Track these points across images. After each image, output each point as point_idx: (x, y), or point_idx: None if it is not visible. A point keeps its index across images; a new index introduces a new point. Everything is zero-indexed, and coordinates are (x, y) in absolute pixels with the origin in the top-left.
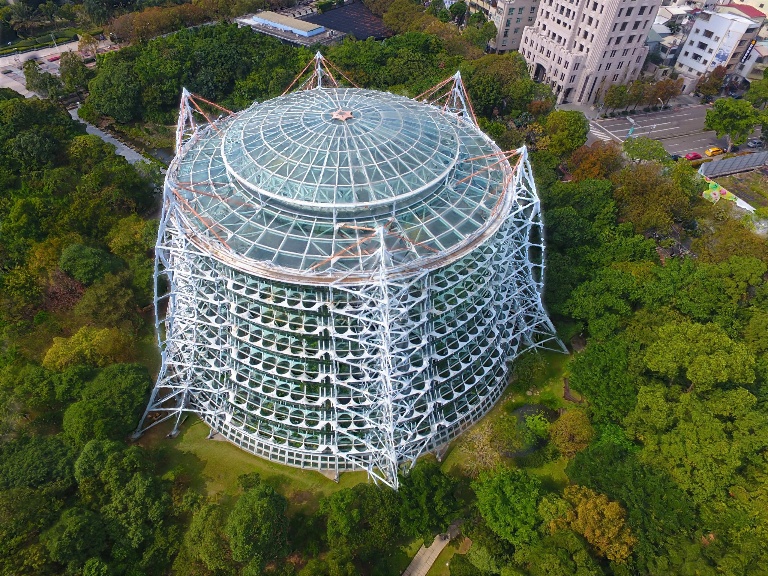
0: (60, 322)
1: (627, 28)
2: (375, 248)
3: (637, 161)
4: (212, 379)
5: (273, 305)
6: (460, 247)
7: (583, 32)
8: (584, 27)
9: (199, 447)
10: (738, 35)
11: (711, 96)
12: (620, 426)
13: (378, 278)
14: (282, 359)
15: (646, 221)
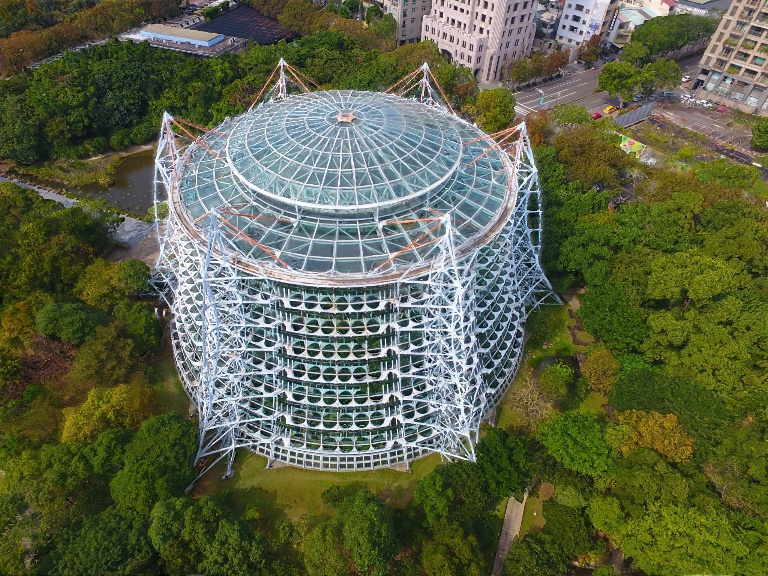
0: (61, 391)
1: (518, 8)
2: (423, 238)
3: (569, 126)
4: (261, 407)
5: (334, 314)
6: (494, 223)
7: (481, 16)
8: (481, 11)
9: (261, 479)
10: (604, 6)
11: (591, 62)
12: (635, 354)
13: (437, 265)
14: (340, 367)
15: (594, 176)
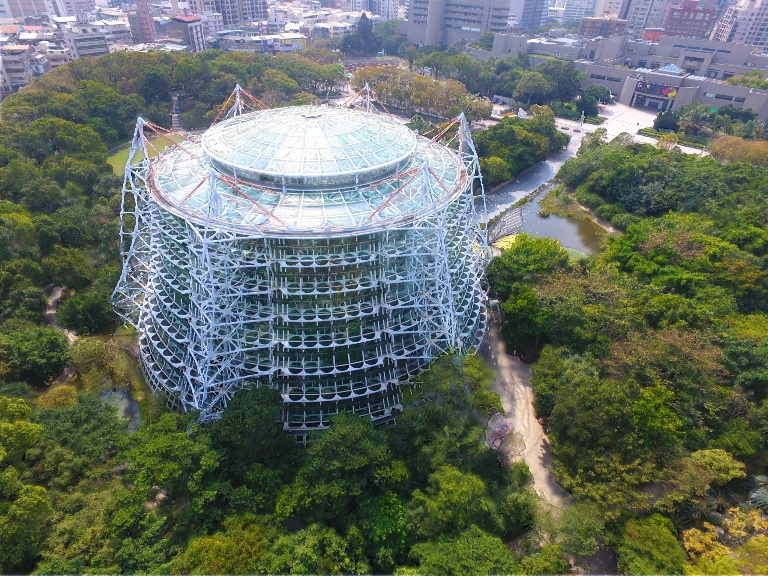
0: None
1: None
2: None
3: None
4: None
5: None
6: None
7: None
8: None
9: None
10: None
11: None
12: None
13: None
14: None
15: None
